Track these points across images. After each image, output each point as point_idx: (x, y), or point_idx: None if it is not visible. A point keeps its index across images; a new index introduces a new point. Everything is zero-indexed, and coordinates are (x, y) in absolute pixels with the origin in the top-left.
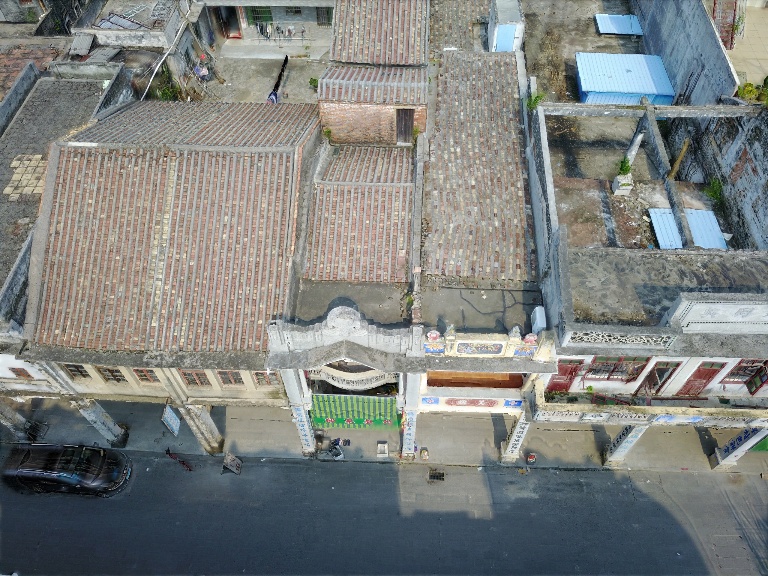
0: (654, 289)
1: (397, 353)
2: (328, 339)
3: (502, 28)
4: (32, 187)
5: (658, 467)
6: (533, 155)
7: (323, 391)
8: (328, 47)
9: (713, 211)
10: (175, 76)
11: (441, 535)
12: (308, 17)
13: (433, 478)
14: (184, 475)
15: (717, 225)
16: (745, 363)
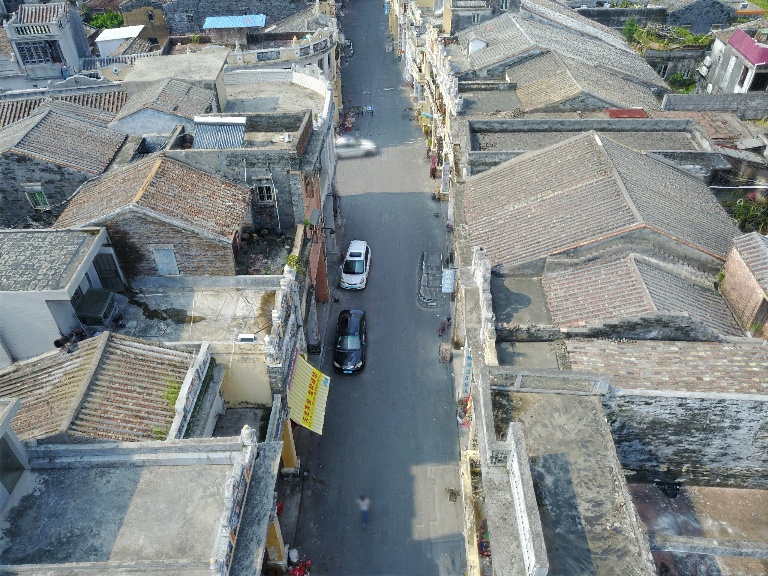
0: (566, 470)
1: None
2: None
3: None
4: None
5: None
6: None
7: None
8: None
9: None
10: None
11: (401, 496)
12: None
13: (451, 492)
14: (436, 334)
15: None
16: None
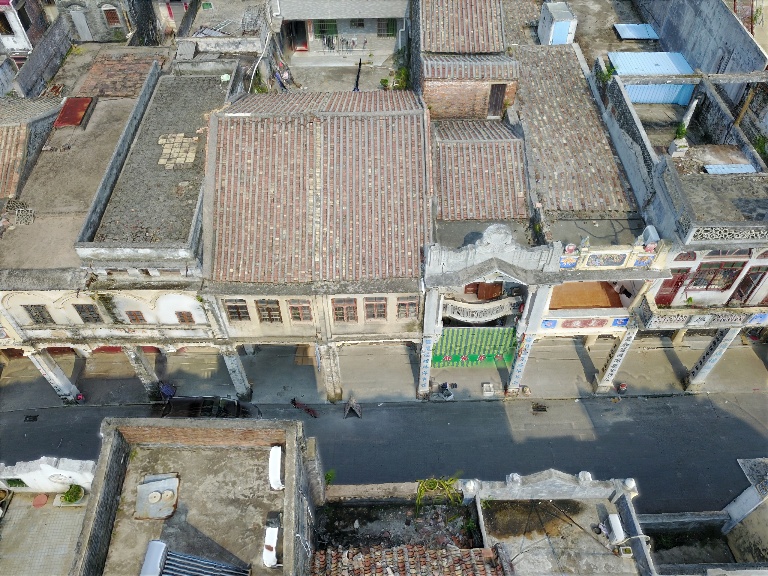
0: (748, 202)
1: (534, 270)
2: (479, 257)
3: (558, 25)
4: (183, 158)
5: (733, 389)
6: (613, 117)
7: (448, 326)
8: (387, 55)
9: None
10: (264, 79)
11: (554, 456)
12: (369, 29)
13: (537, 410)
14: (310, 421)
15: None
16: None
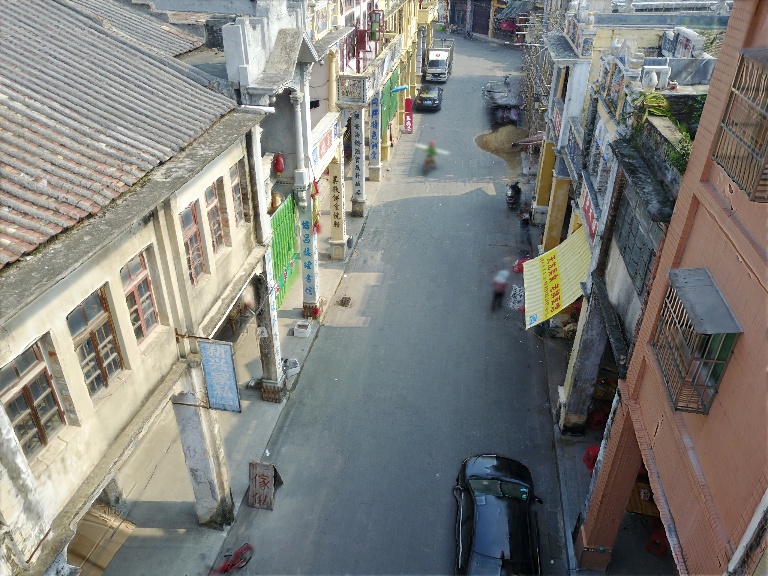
0: None
1: None
2: (272, 32)
3: None
4: None
5: (372, 198)
6: None
7: None
8: None
9: None
10: None
11: (411, 304)
12: None
13: (347, 304)
14: (254, 573)
15: None
16: None
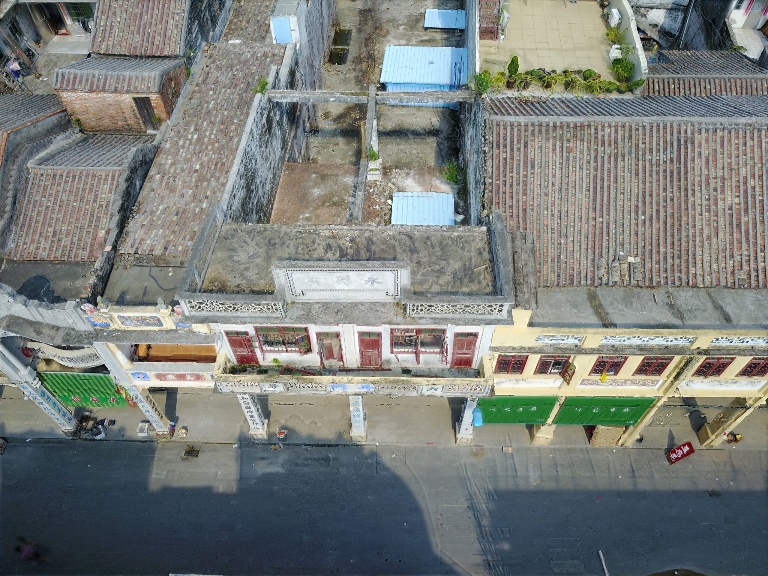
0: None
1: (69, 327)
2: None
3: (276, 21)
4: None
5: (405, 442)
6: None
7: None
8: None
9: (456, 194)
10: None
11: (182, 509)
12: None
13: (188, 455)
14: None
15: (452, 207)
16: (399, 333)
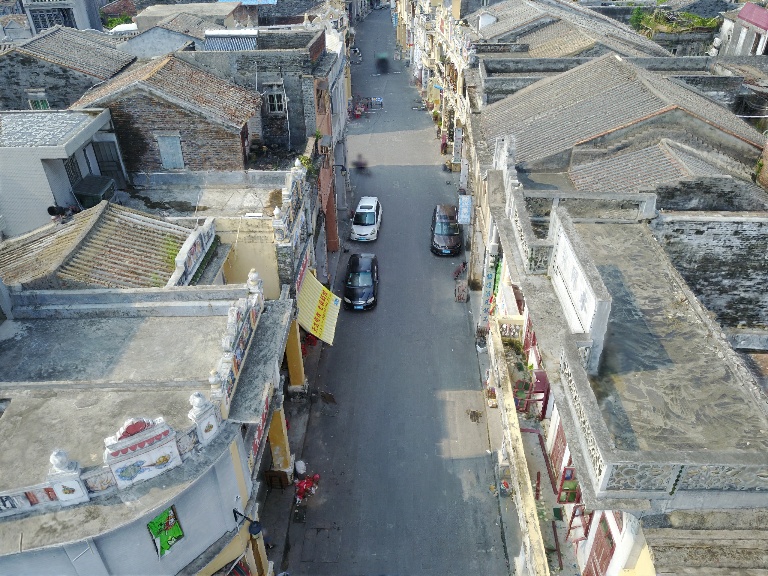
0: (615, 277)
1: None
2: None
3: None
4: None
5: None
6: None
7: None
8: None
9: None
10: None
11: (417, 417)
12: None
13: (472, 414)
14: (451, 278)
15: None
16: None
